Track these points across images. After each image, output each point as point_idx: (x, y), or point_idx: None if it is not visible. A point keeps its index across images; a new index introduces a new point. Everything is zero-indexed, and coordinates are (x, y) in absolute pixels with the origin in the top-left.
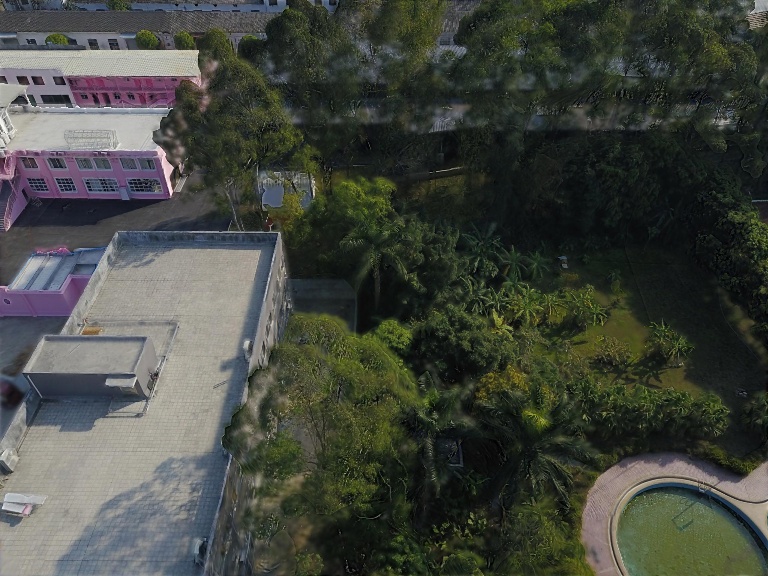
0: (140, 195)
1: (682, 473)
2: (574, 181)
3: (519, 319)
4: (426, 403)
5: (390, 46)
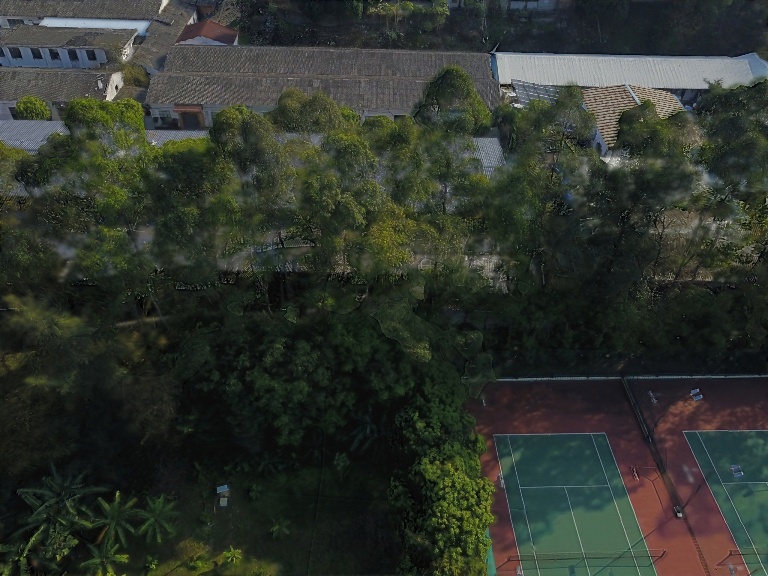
0: None
1: None
2: (217, 394)
3: None
4: None
5: None
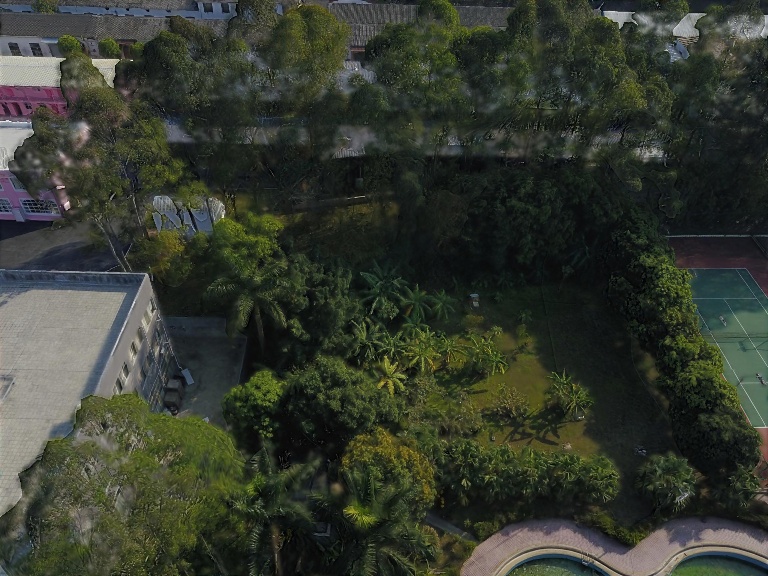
0: (36, 216)
1: (566, 543)
2: (484, 217)
3: (414, 366)
4: (250, 489)
5: (287, 70)
